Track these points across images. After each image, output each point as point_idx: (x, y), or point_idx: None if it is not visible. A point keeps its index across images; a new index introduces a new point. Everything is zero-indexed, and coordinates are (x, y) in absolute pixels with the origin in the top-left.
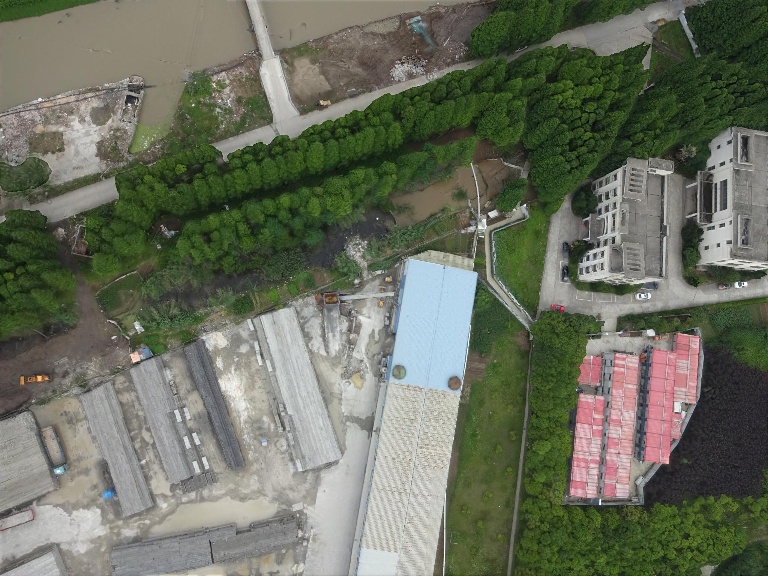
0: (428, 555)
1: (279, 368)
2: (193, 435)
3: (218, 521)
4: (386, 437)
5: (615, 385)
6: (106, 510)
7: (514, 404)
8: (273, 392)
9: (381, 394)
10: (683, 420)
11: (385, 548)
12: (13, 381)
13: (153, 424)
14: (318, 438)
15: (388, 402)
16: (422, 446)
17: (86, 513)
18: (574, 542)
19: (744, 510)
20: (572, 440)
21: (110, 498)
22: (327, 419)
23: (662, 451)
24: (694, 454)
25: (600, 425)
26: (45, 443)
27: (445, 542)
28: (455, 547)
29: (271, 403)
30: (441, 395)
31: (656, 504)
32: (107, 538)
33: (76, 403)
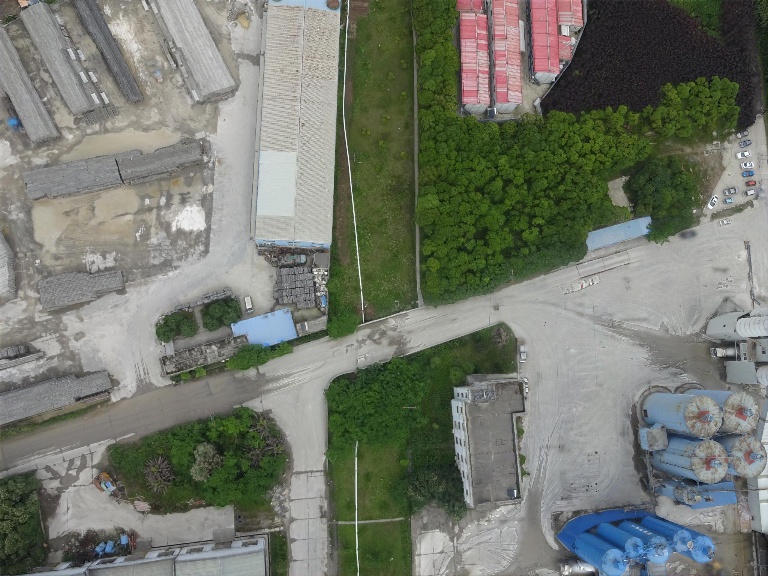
0: (327, 156)
1: (163, 7)
2: (89, 74)
3: (124, 150)
4: (271, 53)
5: (495, 4)
6: (15, 142)
7: (401, 37)
8: (162, 34)
9: (264, 22)
10: (574, 46)
11: (283, 149)
12: None
13: (47, 59)
14: (209, 67)
15: (269, 22)
16: (308, 58)
17: None
18: (470, 139)
19: (648, 125)
20: (459, 55)
21: (17, 132)
22: (216, 50)
23: (551, 61)
24: (585, 66)
25: (485, 40)
26: None
27: (349, 161)
28: (360, 165)
29: (161, 43)
30: (321, 14)
31: (552, 110)
32: (19, 166)
33: None
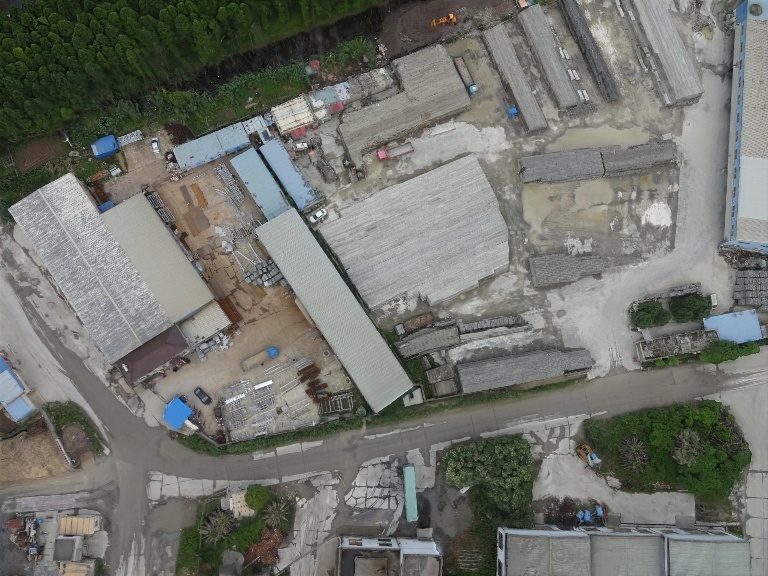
0: None
1: (643, 15)
2: (573, 72)
3: (600, 144)
4: (751, 64)
5: None
6: (509, 129)
7: None
8: (636, 40)
9: (737, 35)
10: None
11: (762, 156)
12: (426, 24)
13: (544, 56)
14: (683, 74)
15: (749, 35)
16: None
17: (493, 130)
18: None
19: None
20: None
21: (511, 120)
22: (688, 58)
23: None
24: None
25: None
26: (458, 70)
27: None
28: None
29: (635, 48)
30: None
31: None
32: (512, 151)
33: (476, 43)
